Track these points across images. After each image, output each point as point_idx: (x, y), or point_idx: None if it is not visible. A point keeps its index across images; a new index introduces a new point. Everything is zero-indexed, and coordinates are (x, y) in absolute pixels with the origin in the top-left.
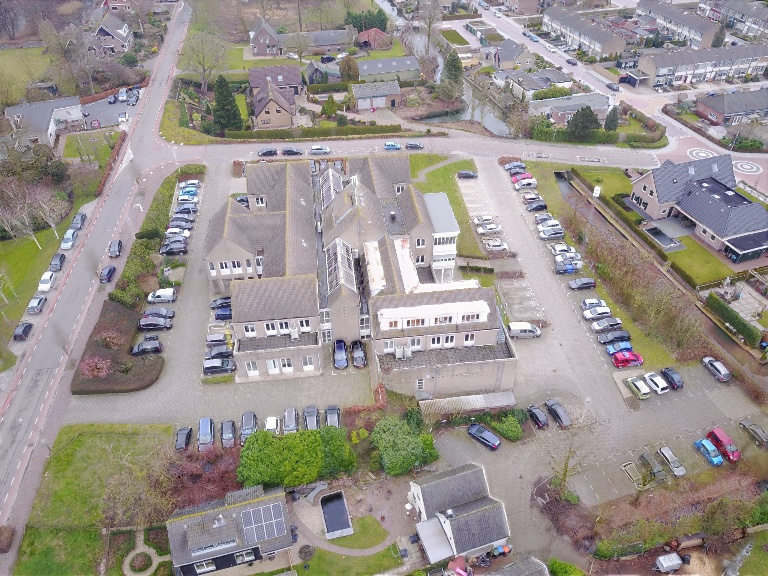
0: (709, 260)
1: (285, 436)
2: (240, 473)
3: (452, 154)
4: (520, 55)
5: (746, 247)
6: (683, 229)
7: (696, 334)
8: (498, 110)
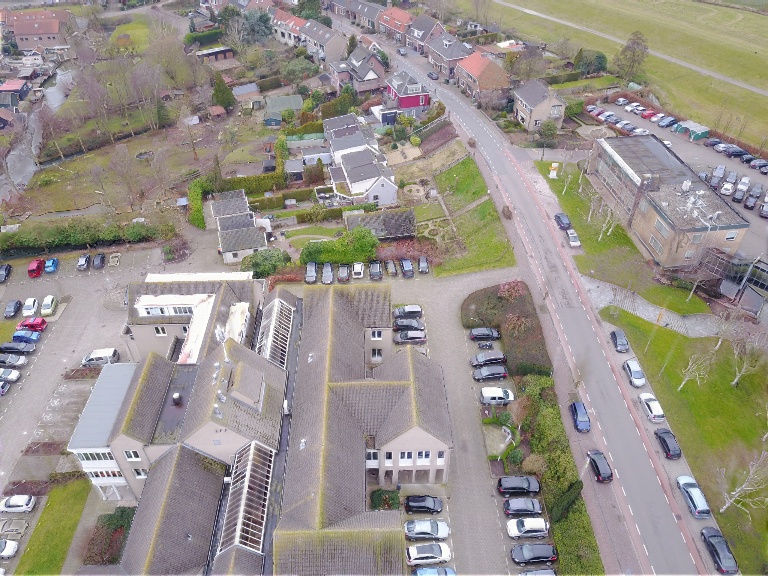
0: None
1: (346, 247)
2: None
3: None
4: None
5: None
6: None
7: None
8: None
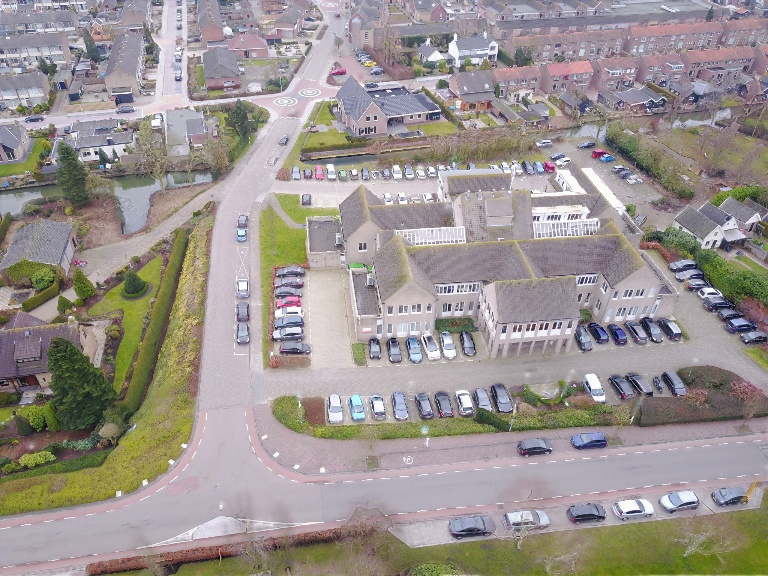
0: (436, 126)
1: (727, 273)
2: (763, 299)
3: (263, 202)
4: (20, 132)
5: (435, 107)
6: (398, 127)
7: (524, 140)
8: (123, 180)
